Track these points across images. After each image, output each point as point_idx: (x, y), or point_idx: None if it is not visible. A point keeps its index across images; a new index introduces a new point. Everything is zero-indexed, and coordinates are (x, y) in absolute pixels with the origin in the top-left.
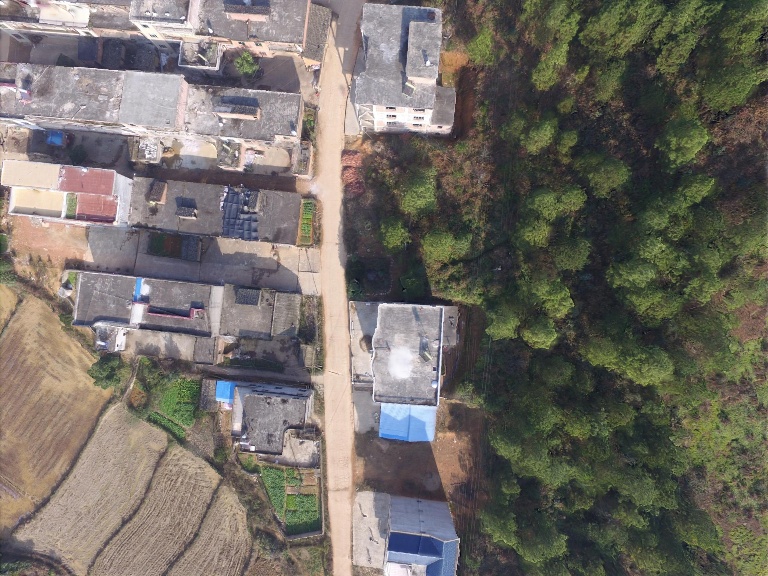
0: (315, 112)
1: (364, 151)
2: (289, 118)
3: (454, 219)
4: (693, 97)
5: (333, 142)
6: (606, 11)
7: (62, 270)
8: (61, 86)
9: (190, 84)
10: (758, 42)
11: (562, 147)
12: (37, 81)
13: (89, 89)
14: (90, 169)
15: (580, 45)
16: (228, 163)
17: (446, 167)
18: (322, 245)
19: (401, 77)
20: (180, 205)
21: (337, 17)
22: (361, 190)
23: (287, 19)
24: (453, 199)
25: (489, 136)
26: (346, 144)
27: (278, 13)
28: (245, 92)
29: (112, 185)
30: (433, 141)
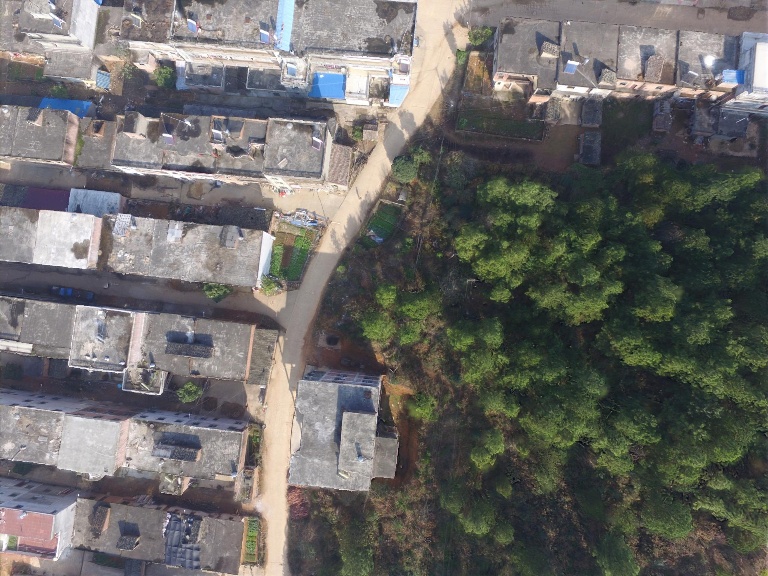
0: (261, 430)
1: None
2: (230, 457)
3: (396, 568)
4: (635, 497)
5: (279, 460)
6: (543, 417)
7: (9, 574)
8: (2, 425)
9: (132, 418)
10: (697, 480)
11: (499, 540)
12: None
13: (29, 430)
14: (29, 513)
15: (521, 427)
16: (171, 490)
17: (388, 513)
18: (266, 565)
19: (336, 457)
20: (123, 529)
21: (284, 331)
22: (306, 514)
23: (229, 355)
24: (395, 545)
25: (431, 492)
26: None
27: (220, 348)
28: (186, 429)
29: (51, 530)
30: (376, 484)
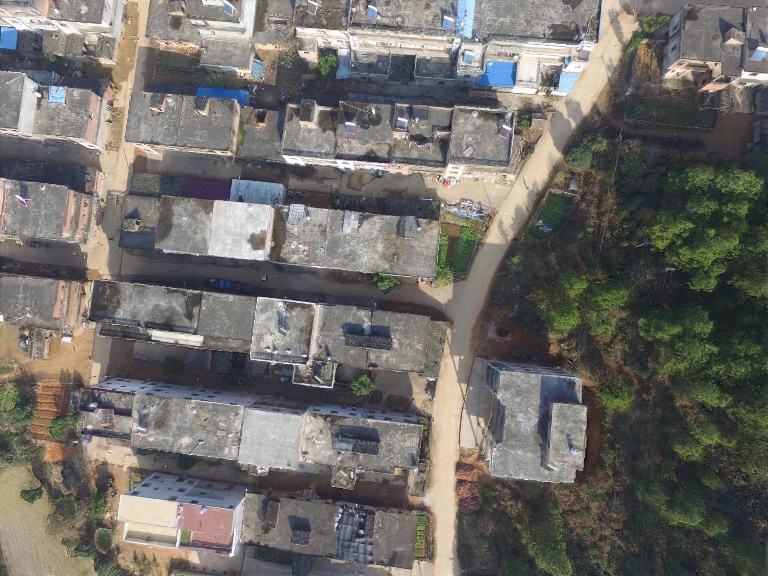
0: (429, 424)
1: (481, 468)
2: (410, 450)
3: (581, 561)
4: None
5: (447, 453)
6: (764, 407)
7: (168, 570)
8: (178, 419)
9: (307, 412)
10: None
11: (710, 532)
12: (154, 414)
13: (207, 424)
14: (209, 508)
15: (727, 417)
16: (343, 484)
17: (573, 506)
18: (436, 560)
19: (540, 449)
20: (293, 524)
21: (452, 323)
22: (477, 507)
23: (408, 347)
24: (579, 538)
25: (621, 484)
26: (461, 456)
27: (398, 340)
28: (364, 422)
29: (231, 525)
30: None
